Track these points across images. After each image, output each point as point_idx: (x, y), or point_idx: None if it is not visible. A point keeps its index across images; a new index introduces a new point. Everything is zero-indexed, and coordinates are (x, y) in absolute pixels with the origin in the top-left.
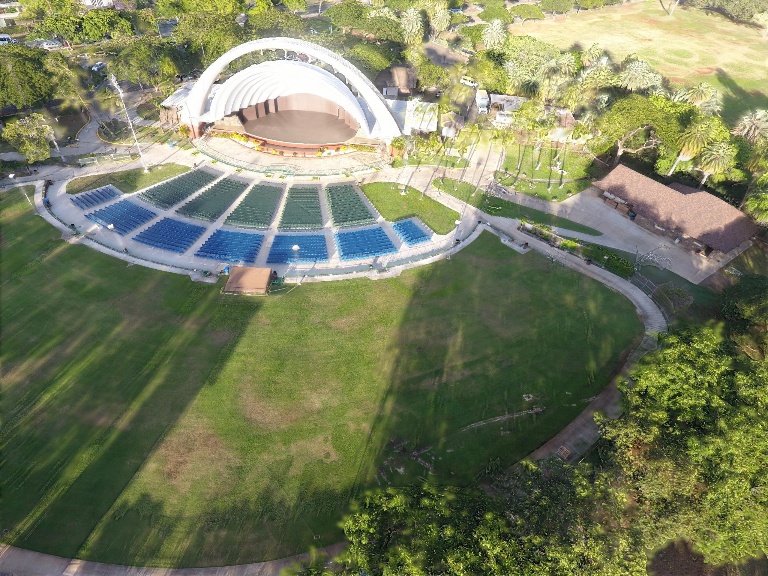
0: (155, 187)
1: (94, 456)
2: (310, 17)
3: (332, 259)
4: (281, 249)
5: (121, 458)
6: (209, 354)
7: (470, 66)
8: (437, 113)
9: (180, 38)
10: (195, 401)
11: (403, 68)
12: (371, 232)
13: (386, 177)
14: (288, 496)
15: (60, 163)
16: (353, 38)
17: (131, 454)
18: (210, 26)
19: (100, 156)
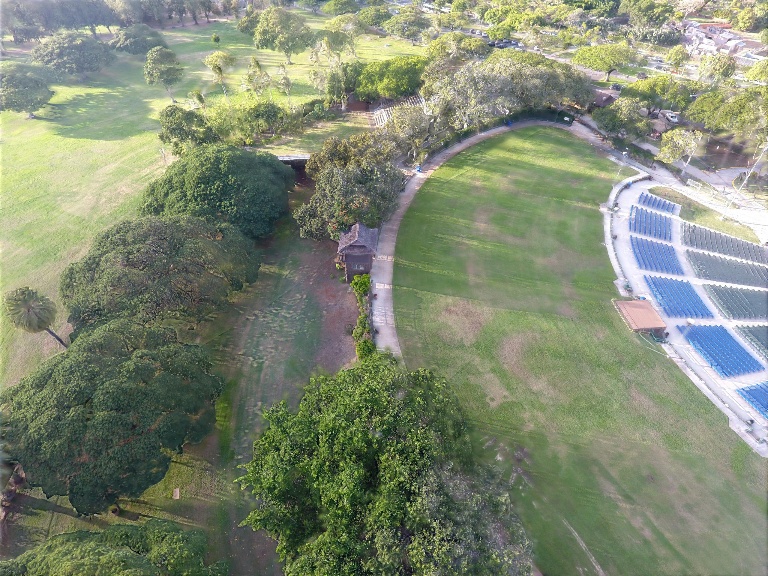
0: (704, 228)
1: (448, 275)
2: None
3: (731, 382)
4: (705, 333)
5: (450, 286)
6: (546, 307)
7: None
8: None
9: None
10: (503, 309)
11: None
12: None
13: None
14: (453, 377)
15: (677, 174)
16: None
17: (454, 289)
18: None
19: (710, 189)
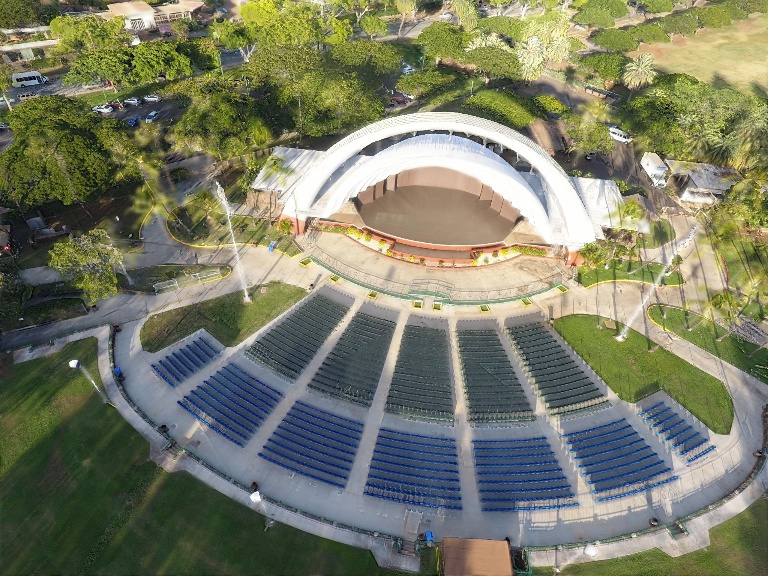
0: (268, 335)
1: None
2: (388, 41)
3: (580, 497)
4: (495, 476)
5: None
6: None
7: (627, 118)
8: (622, 198)
9: (255, 81)
10: None
11: (537, 119)
12: (616, 431)
13: (580, 305)
14: None
15: (126, 288)
16: (448, 70)
17: None
18: (293, 66)
19: (178, 270)
